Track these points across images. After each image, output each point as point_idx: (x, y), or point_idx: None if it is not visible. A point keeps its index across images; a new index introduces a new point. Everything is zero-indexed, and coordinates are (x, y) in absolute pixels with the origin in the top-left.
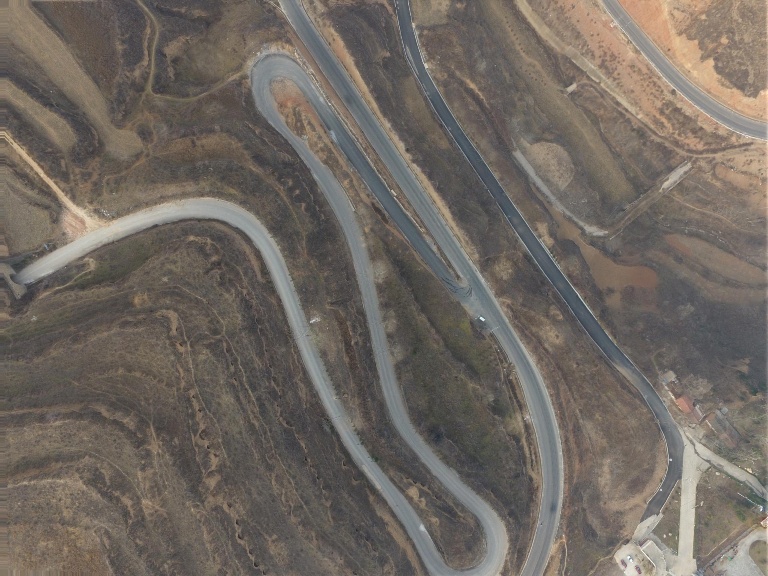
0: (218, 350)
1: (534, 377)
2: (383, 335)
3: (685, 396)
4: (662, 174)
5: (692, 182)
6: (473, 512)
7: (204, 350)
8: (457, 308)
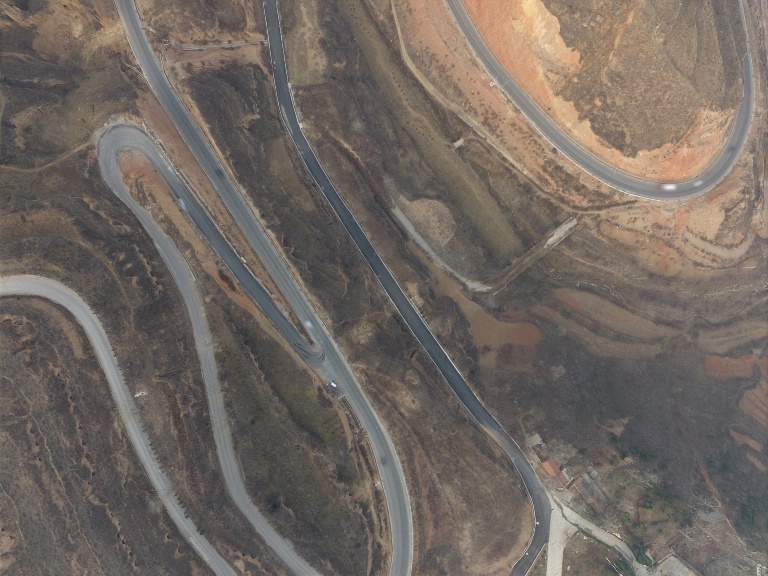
0: (18, 432)
1: (385, 443)
2: (221, 404)
3: (551, 460)
4: (550, 229)
5: (579, 238)
6: None
7: (4, 432)
8: (302, 376)
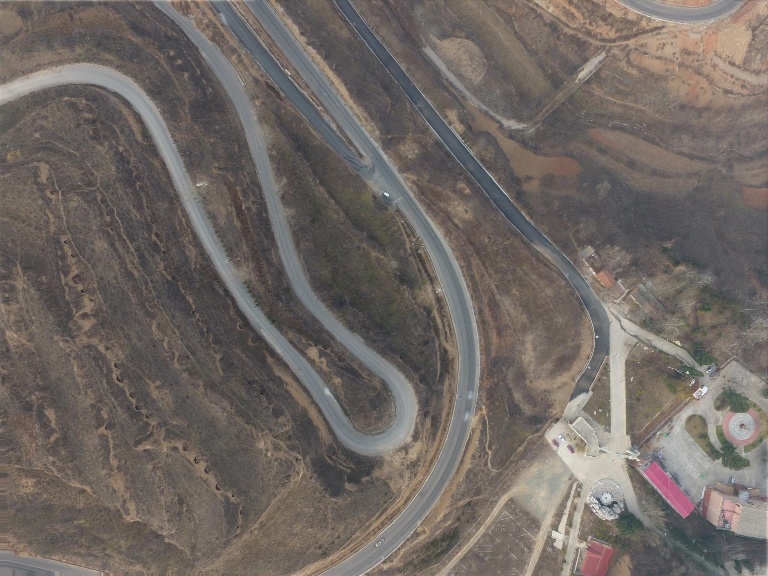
0: (89, 197)
1: (443, 250)
2: (279, 205)
3: (605, 270)
4: (579, 67)
5: (609, 72)
6: (380, 376)
7: (75, 197)
8: (356, 180)
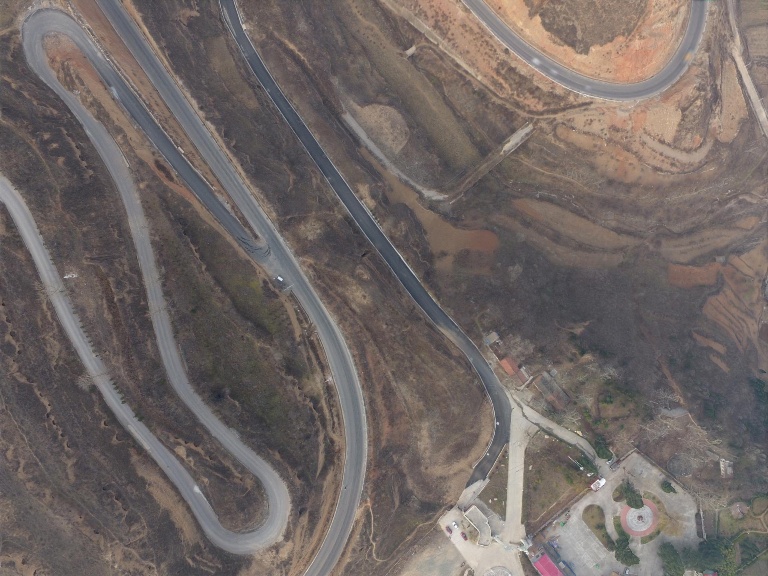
0: None
1: (336, 337)
2: (160, 293)
3: (509, 358)
4: (507, 137)
5: (536, 144)
6: (254, 473)
7: None
8: (246, 266)
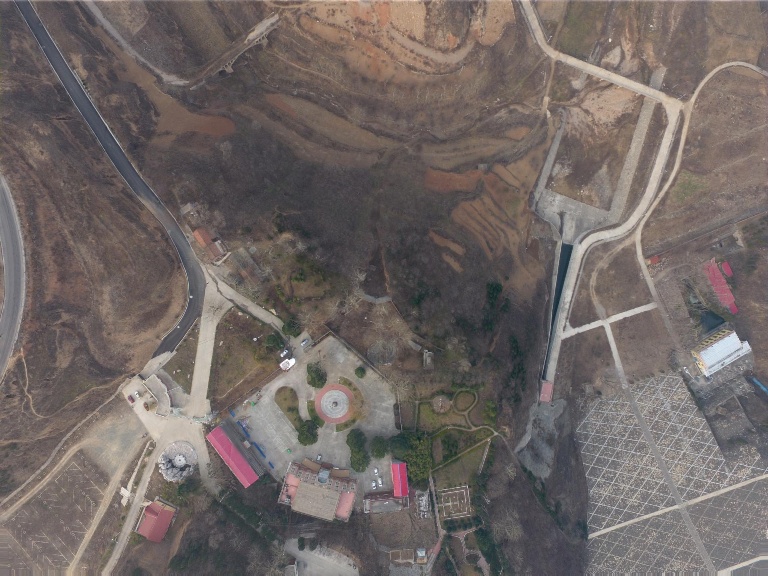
0: None
1: (2, 187)
2: None
3: (202, 230)
4: None
5: (285, 36)
6: None
7: None
8: None
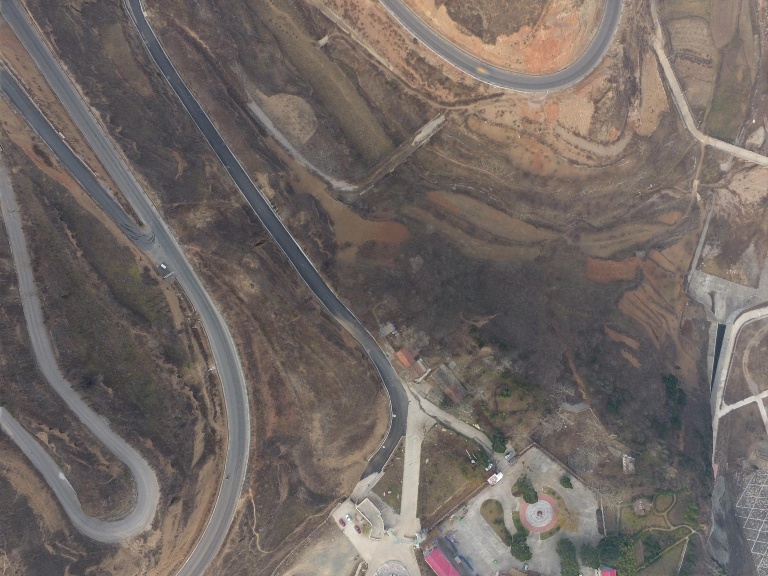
0: None
1: (219, 326)
2: (31, 279)
3: (405, 349)
4: None
5: (450, 136)
6: (123, 461)
7: None
8: (124, 253)
